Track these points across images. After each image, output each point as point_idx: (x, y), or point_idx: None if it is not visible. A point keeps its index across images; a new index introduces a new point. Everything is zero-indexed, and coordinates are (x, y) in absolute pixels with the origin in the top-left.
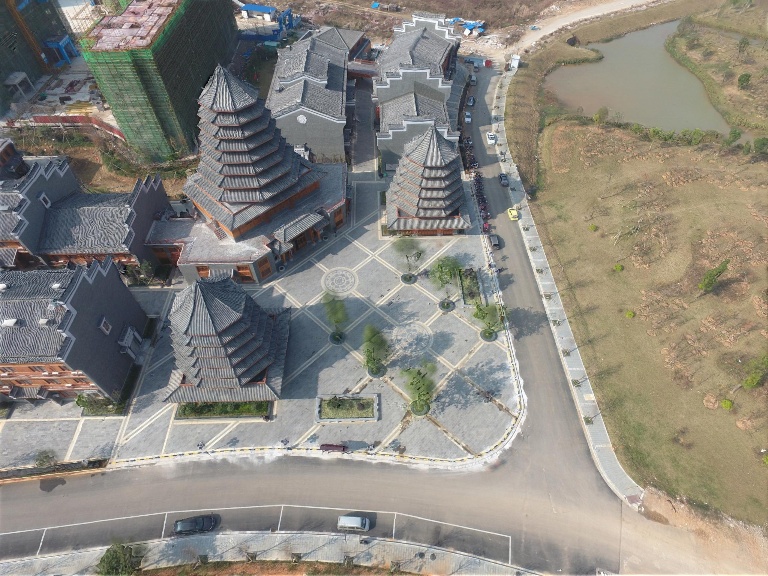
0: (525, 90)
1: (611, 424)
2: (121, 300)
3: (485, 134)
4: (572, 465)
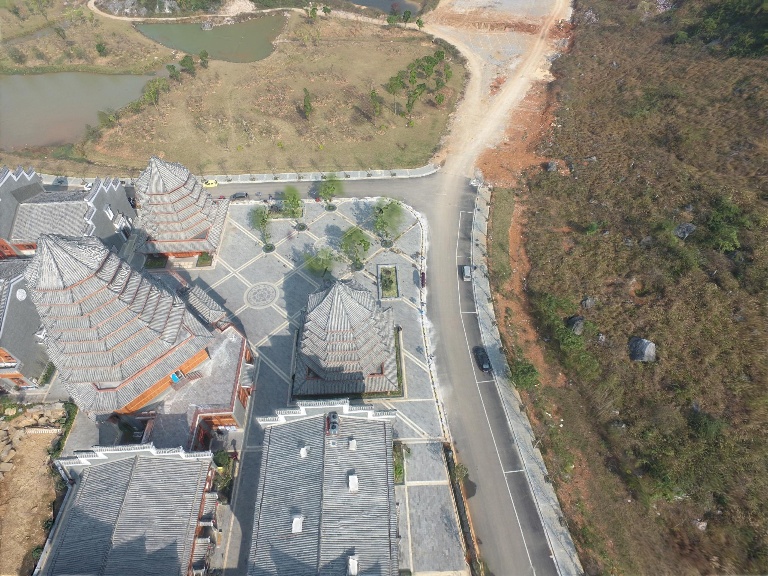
0: (15, 160)
1: (395, 167)
2: None
3: None
4: (420, 185)
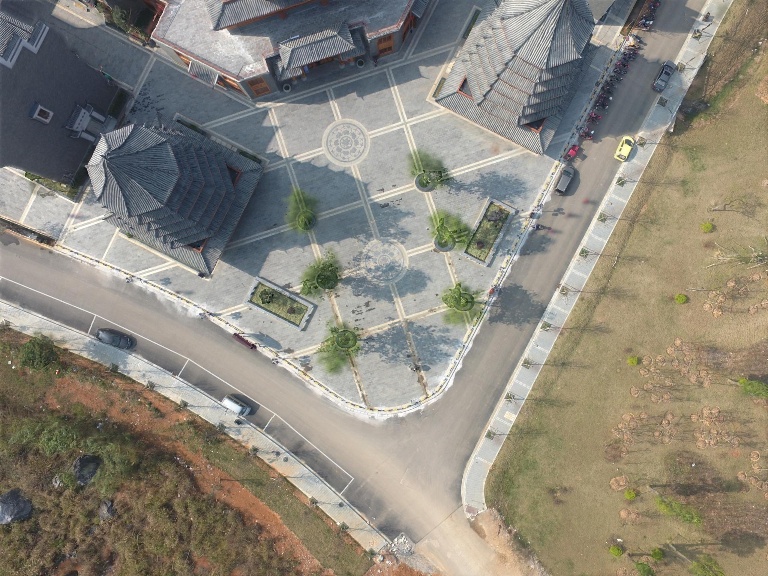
0: None
1: (508, 448)
2: (69, 77)
3: None
4: (444, 459)
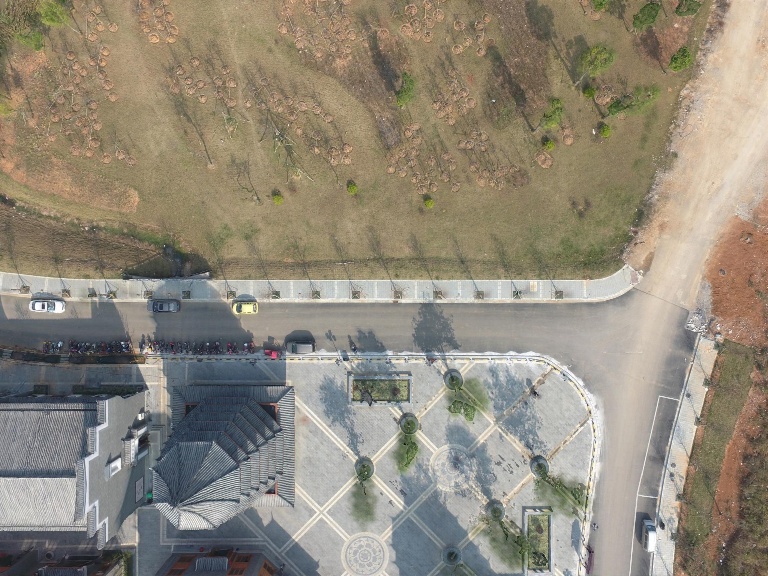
0: None
1: (563, 273)
2: None
3: (31, 312)
4: (601, 325)
